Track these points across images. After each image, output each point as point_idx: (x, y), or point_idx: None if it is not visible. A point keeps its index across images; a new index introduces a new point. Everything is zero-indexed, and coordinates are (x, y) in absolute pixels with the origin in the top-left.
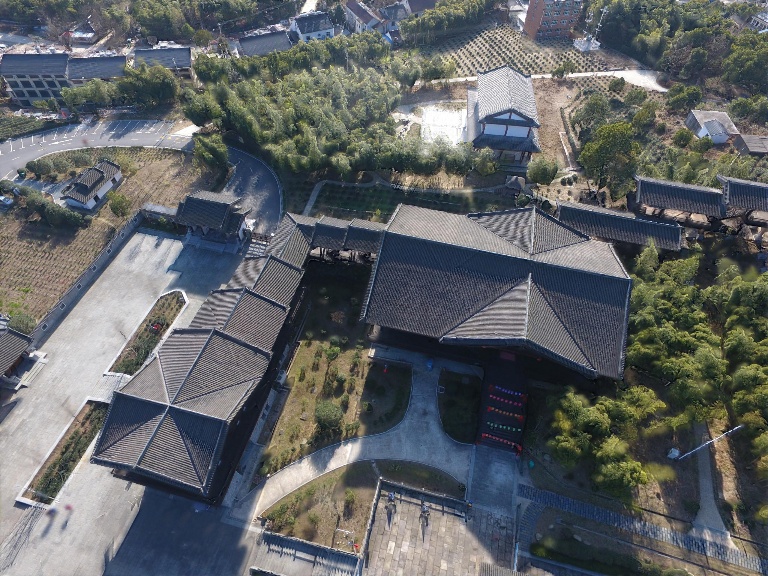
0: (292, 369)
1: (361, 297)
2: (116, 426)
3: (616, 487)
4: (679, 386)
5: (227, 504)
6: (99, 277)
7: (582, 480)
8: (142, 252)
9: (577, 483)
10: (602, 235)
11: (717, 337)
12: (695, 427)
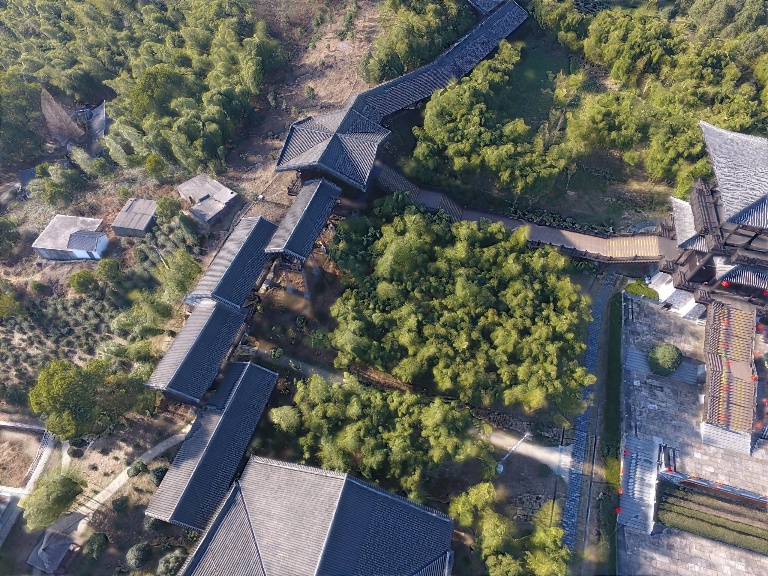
0: None
1: None
2: None
3: None
4: None
5: None
6: None
7: None
8: None
9: None
10: (235, 465)
11: (409, 395)
12: None
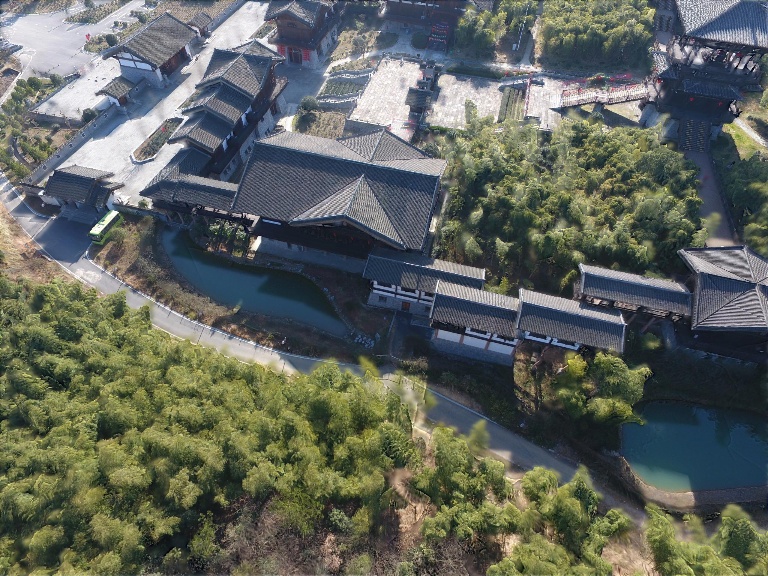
0: (339, 38)
1: (374, 18)
2: (274, 7)
3: (482, 39)
4: (515, 11)
5: (314, 67)
6: (233, 14)
7: (473, 55)
8: (253, 7)
9: (470, 56)
10: None
11: None
12: (528, 43)
